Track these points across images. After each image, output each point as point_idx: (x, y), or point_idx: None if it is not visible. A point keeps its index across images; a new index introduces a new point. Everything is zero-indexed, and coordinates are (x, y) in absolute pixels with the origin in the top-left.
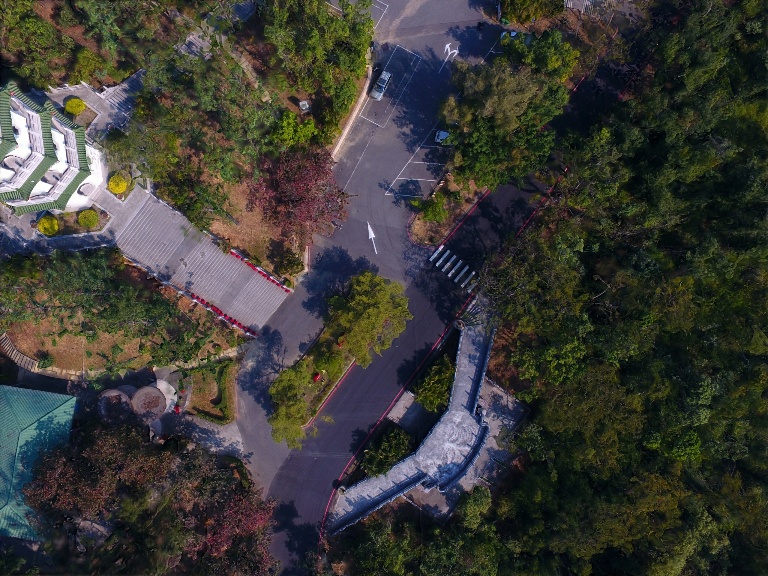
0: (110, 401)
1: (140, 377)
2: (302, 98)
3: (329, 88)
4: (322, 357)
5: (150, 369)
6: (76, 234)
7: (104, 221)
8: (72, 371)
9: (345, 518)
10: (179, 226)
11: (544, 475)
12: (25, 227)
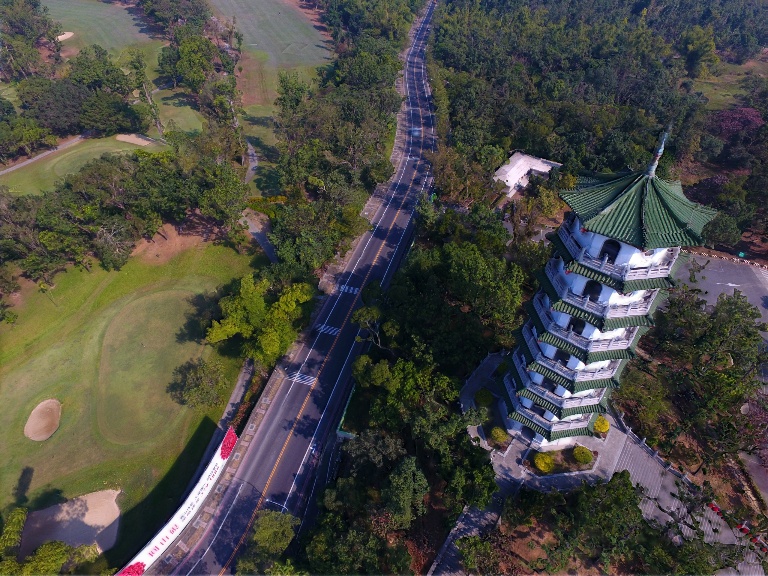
0: None
1: None
2: (690, 368)
3: (748, 351)
4: None
5: None
6: (567, 473)
7: (591, 460)
8: None
9: None
10: (654, 470)
11: None
12: (511, 465)
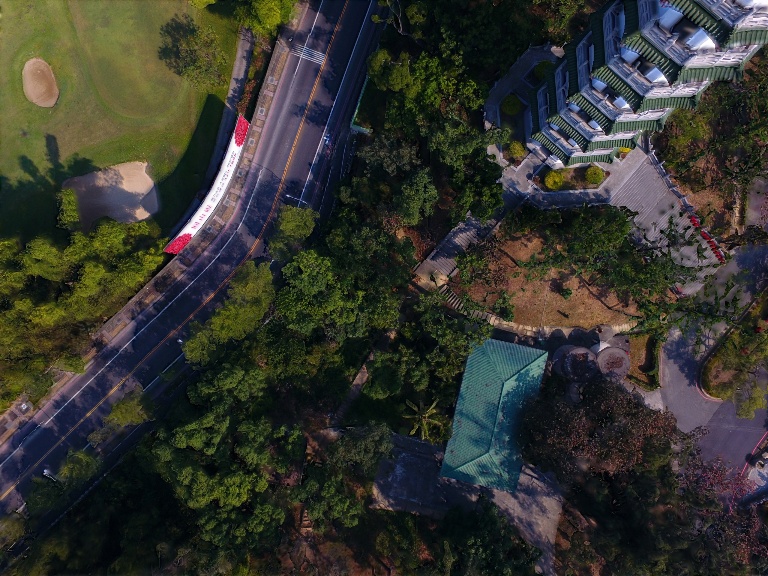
0: (577, 359)
1: (584, 338)
2: None
3: None
4: (765, 331)
5: (601, 330)
6: (572, 190)
7: None
8: (529, 327)
9: (757, 492)
10: (657, 190)
11: None
12: (521, 180)
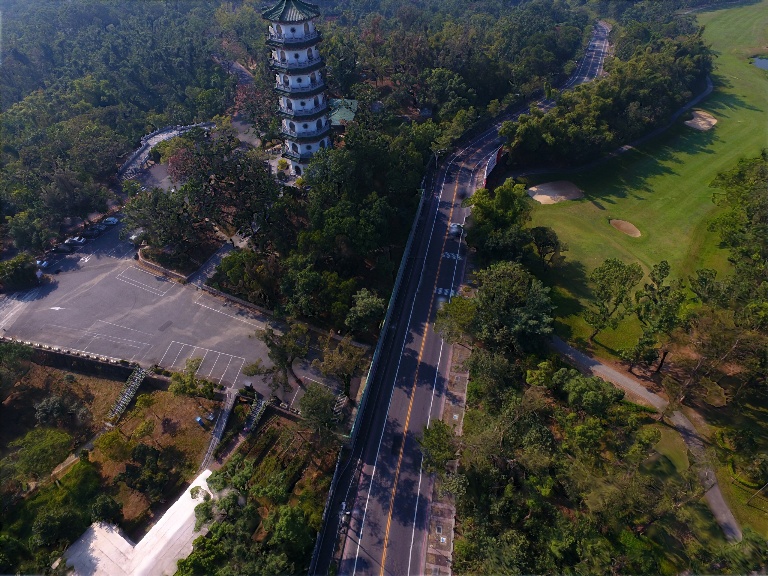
0: None
1: None
2: None
3: None
4: None
5: None
6: None
7: None
8: None
9: None
10: None
11: (126, 135)
12: None
